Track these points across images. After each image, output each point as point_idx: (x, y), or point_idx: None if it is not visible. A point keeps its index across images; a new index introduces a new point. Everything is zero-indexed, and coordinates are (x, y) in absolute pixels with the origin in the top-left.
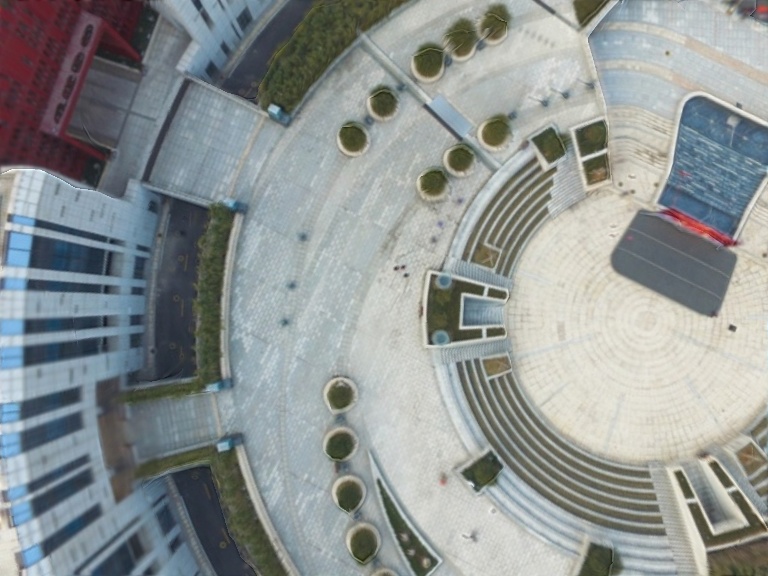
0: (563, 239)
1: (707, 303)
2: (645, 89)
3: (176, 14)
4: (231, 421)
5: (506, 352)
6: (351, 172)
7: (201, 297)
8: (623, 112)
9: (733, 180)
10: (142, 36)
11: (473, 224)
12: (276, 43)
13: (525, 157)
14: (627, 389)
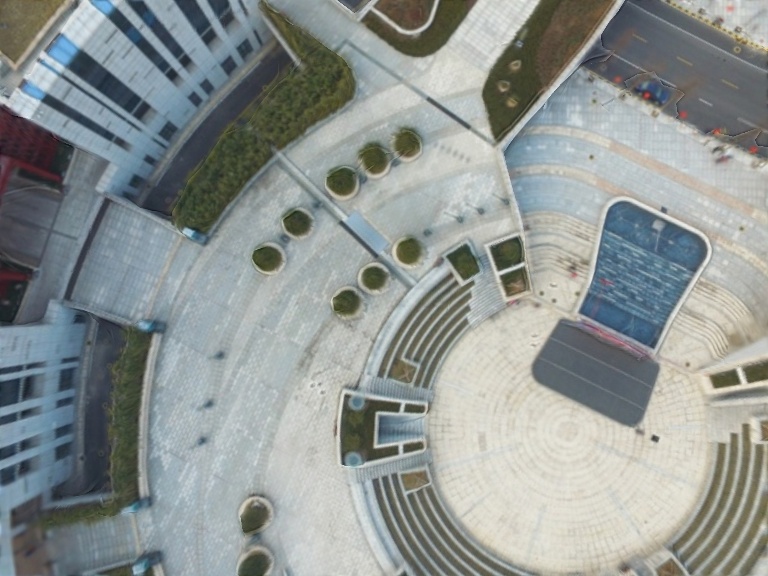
0: (484, 349)
1: (629, 414)
2: (569, 194)
3: (86, 148)
4: (150, 539)
5: (425, 465)
6: (267, 290)
7: (116, 421)
8: (546, 218)
9: (657, 287)
10: (62, 158)
11: (389, 341)
12: (202, 151)
13: (440, 273)
14: (548, 500)
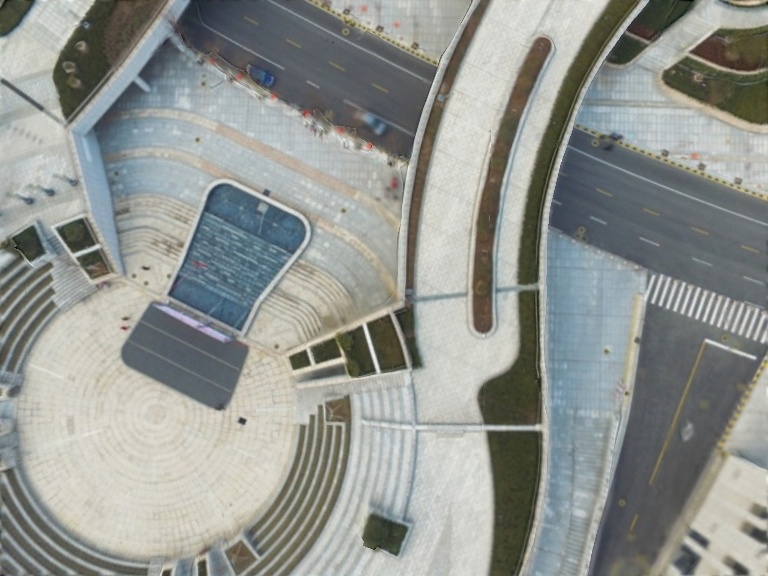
0: (75, 332)
1: (214, 396)
2: (173, 177)
3: None
4: None
5: (4, 449)
6: None
7: None
8: (147, 201)
9: (252, 269)
10: None
11: None
12: None
13: (8, 255)
14: (135, 483)
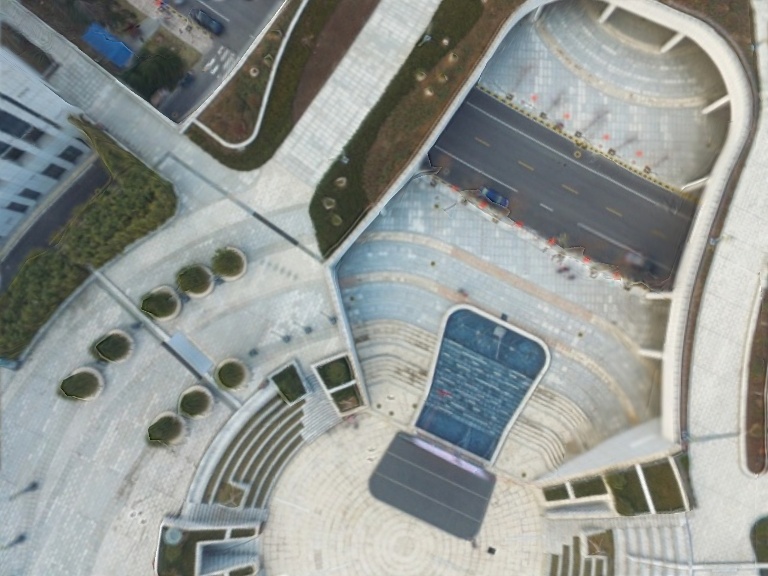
0: (320, 464)
1: (465, 527)
2: (410, 302)
3: None
4: None
5: None
6: (84, 416)
7: None
8: (386, 327)
9: (495, 396)
10: None
11: (213, 466)
12: None
13: (266, 395)
14: None
